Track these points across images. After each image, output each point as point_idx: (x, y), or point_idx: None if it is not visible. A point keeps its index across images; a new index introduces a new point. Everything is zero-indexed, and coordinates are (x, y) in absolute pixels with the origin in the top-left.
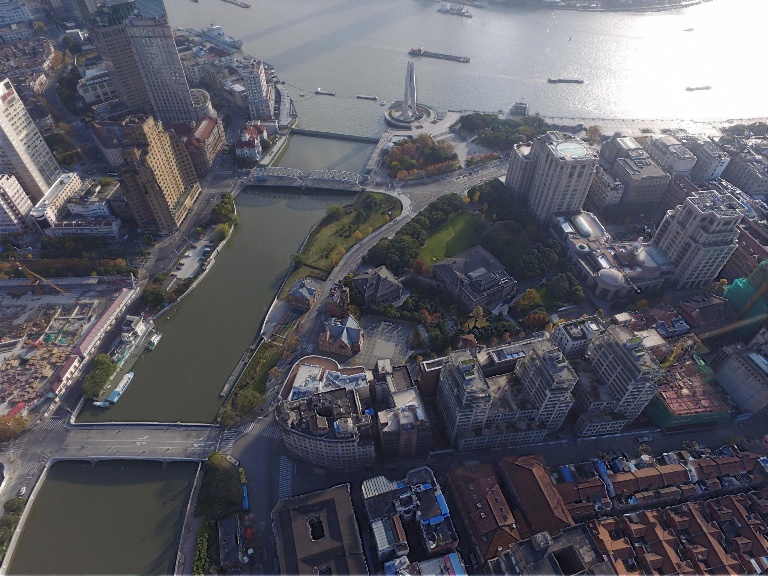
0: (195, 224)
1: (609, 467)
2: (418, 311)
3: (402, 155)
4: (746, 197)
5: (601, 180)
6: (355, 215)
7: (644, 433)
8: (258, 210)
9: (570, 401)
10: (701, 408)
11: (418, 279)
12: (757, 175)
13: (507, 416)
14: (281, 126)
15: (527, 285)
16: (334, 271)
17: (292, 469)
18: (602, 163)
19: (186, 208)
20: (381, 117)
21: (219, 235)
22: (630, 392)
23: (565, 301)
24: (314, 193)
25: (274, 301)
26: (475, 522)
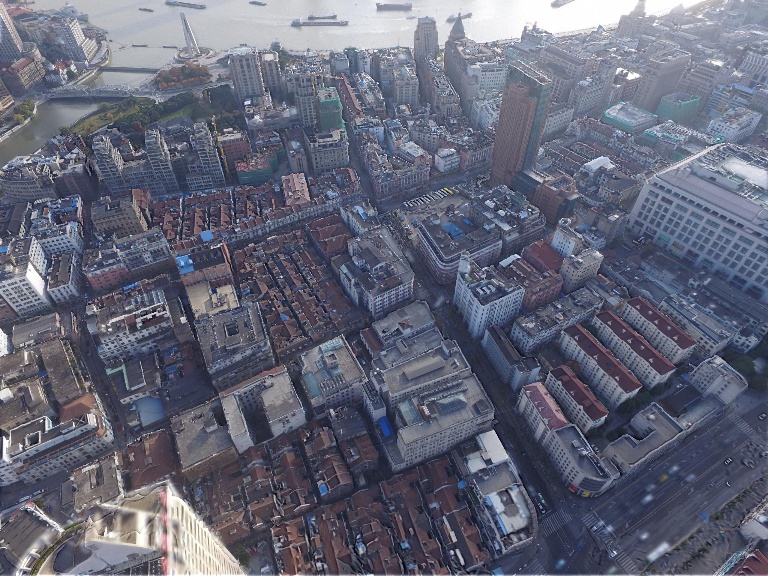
0: None
1: None
2: None
3: (166, 74)
4: None
5: (286, 77)
6: None
7: None
8: (54, 112)
9: (165, 160)
10: (256, 169)
11: None
12: (381, 67)
13: (138, 175)
14: (91, 65)
15: None
16: None
17: None
18: None
19: None
20: (173, 57)
21: None
22: (200, 154)
23: None
24: (98, 101)
25: (38, 150)
26: None
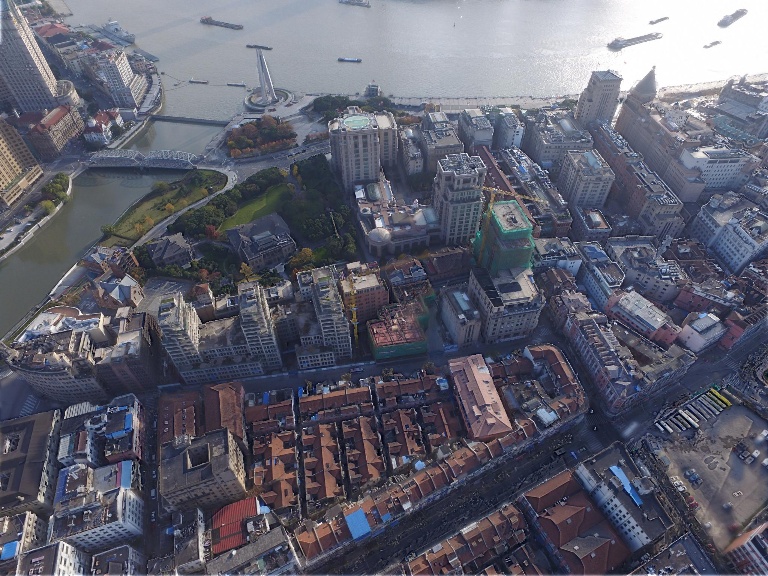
0: (27, 203)
1: (307, 392)
2: (197, 270)
3: (240, 135)
4: (529, 162)
5: (406, 151)
6: (178, 190)
7: (360, 365)
8: (94, 189)
9: (268, 334)
10: (402, 340)
11: (212, 244)
12: (543, 142)
13: (223, 351)
14: (141, 113)
15: (312, 246)
16: (140, 240)
17: (35, 405)
18: (417, 136)
19: (20, 189)
20: (242, 102)
21: (44, 212)
22: (323, 325)
23: (337, 258)
24: (152, 173)
25: (73, 267)
26: (160, 436)
